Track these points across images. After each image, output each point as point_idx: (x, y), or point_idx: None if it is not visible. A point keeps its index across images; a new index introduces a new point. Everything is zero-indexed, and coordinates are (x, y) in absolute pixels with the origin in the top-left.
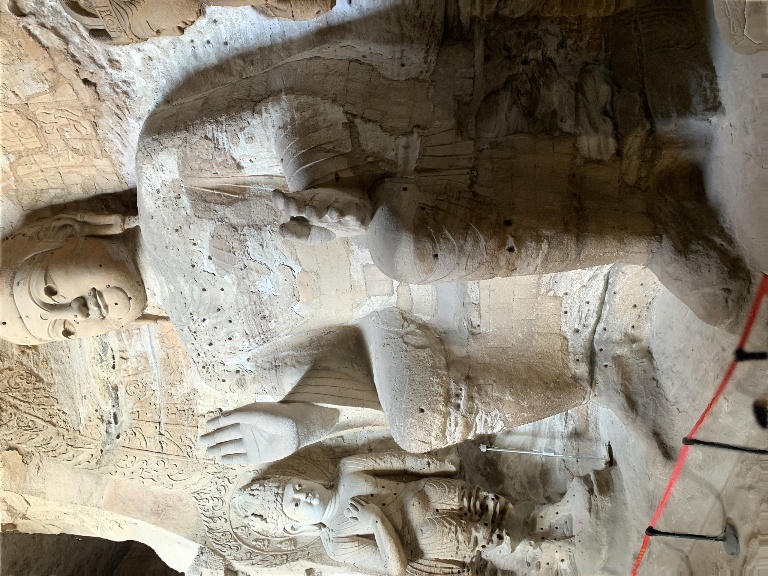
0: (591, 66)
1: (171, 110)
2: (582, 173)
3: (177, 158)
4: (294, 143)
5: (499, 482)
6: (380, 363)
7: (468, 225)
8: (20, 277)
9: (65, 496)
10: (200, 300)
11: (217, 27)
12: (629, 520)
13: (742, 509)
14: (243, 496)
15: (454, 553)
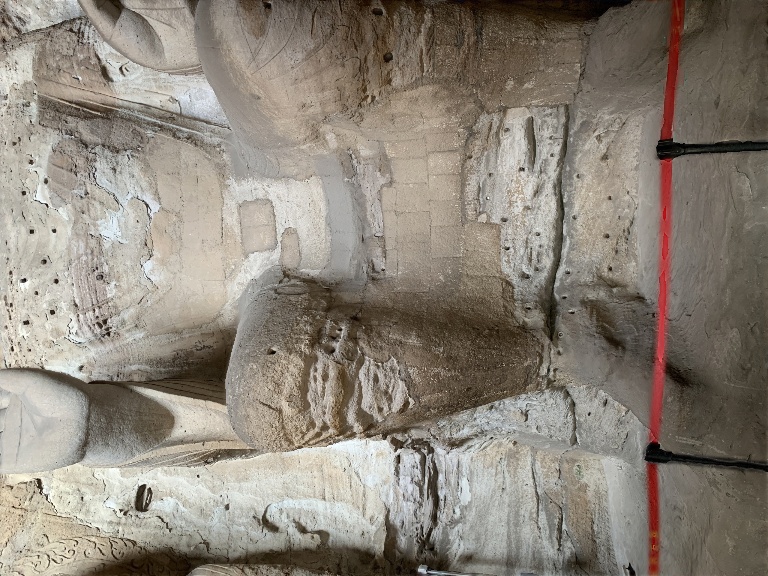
0: None
1: None
2: None
3: (34, 53)
4: None
5: None
6: None
7: None
8: None
9: None
10: (24, 248)
11: None
12: None
13: None
14: None
15: None
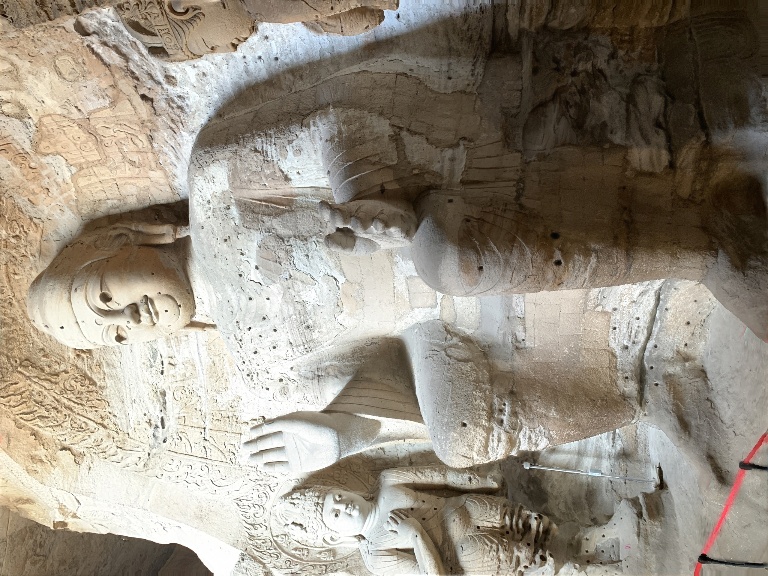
0: (643, 77)
1: (223, 124)
2: (633, 186)
3: (227, 170)
4: (341, 155)
5: (543, 501)
6: (422, 375)
7: (514, 238)
8: (78, 284)
9: (113, 497)
10: (246, 309)
11: (268, 43)
12: (680, 547)
13: None
14: (284, 504)
15: (495, 572)
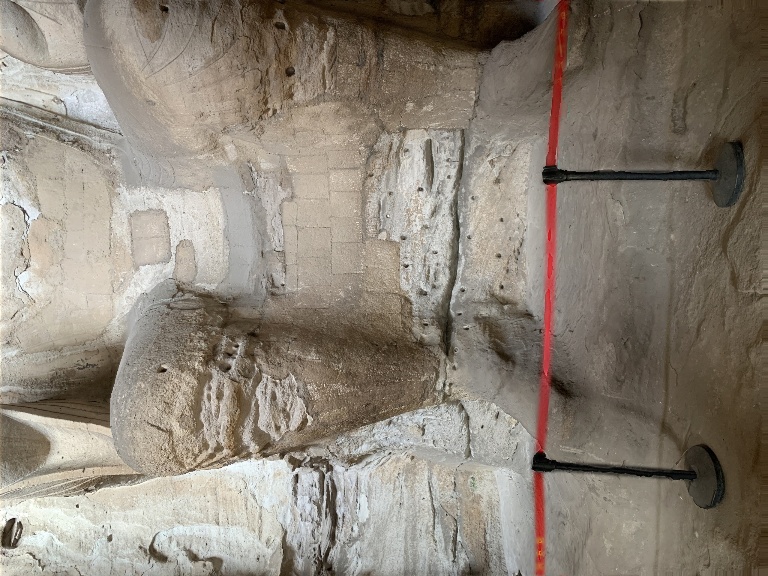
0: None
1: None
2: (391, 19)
3: None
4: None
5: None
6: None
7: None
8: None
9: None
10: None
11: None
12: None
13: (701, 390)
14: None
15: None
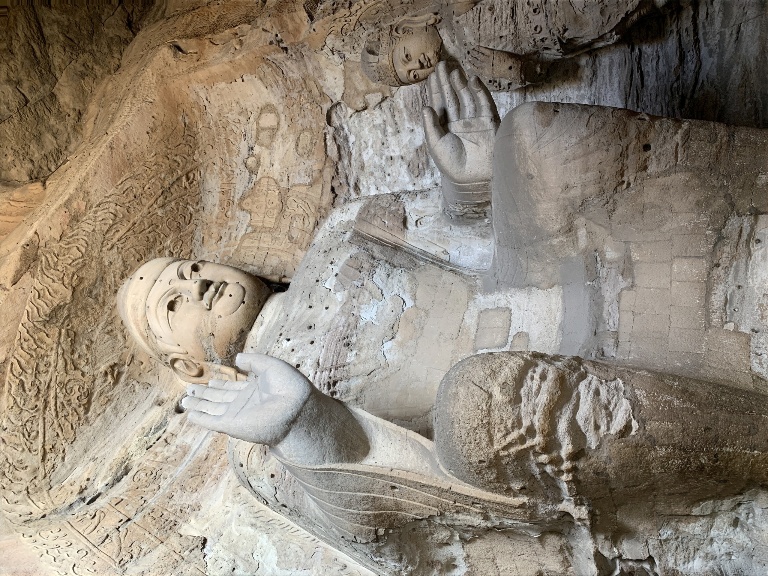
0: None
1: None
2: None
3: (363, 205)
4: None
5: None
6: None
7: None
8: None
9: None
10: (300, 318)
11: None
12: None
13: None
14: None
15: None
